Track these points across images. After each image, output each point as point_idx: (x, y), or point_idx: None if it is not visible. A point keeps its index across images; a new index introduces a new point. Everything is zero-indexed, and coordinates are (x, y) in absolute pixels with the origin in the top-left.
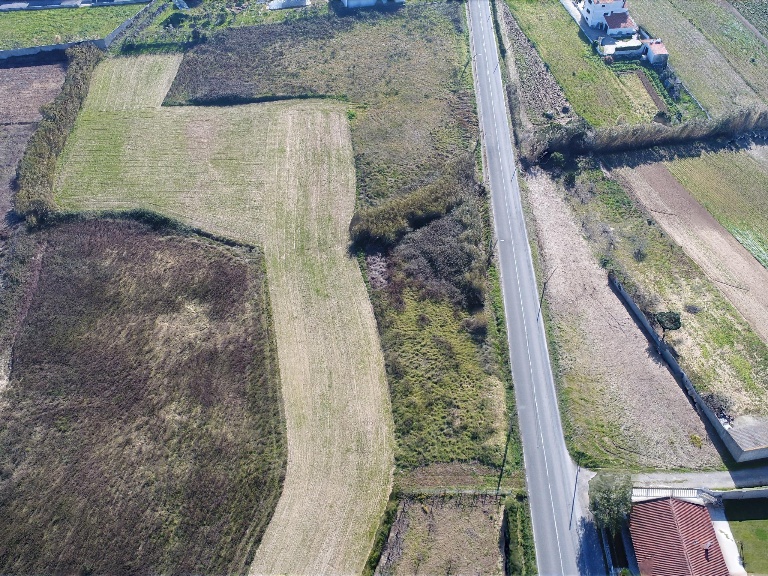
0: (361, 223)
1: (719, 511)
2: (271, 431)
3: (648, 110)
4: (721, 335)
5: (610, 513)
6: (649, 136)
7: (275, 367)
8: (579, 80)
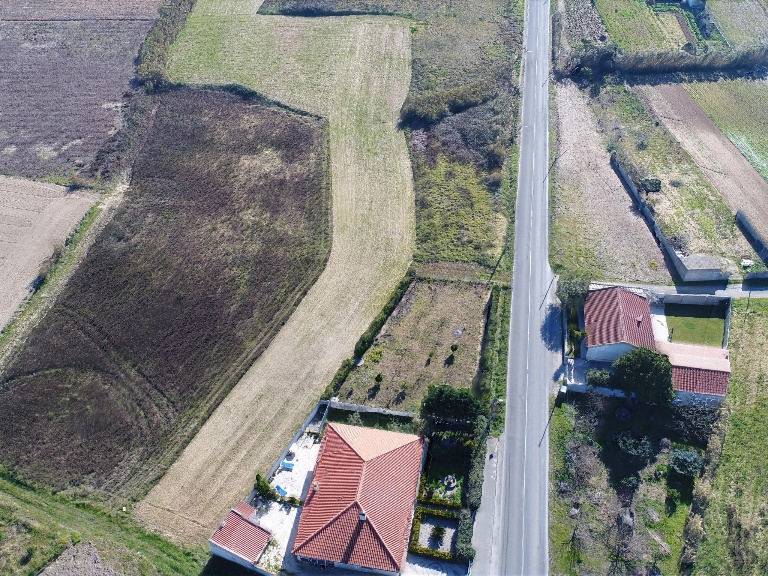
0: (410, 104)
1: (660, 309)
2: (321, 232)
3: (678, 43)
4: (695, 202)
5: (569, 292)
6: (673, 61)
7: (329, 194)
8: (620, 16)
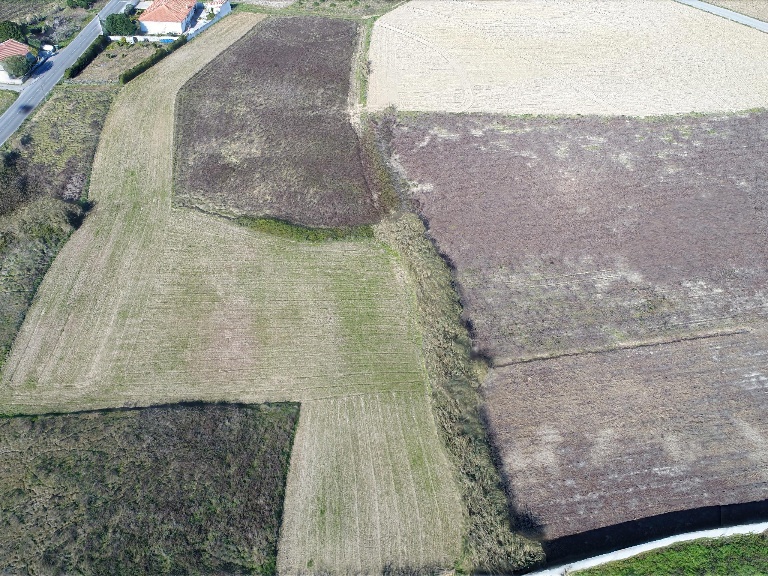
0: (69, 204)
1: None
2: None
3: None
4: None
5: None
6: None
7: None
8: None
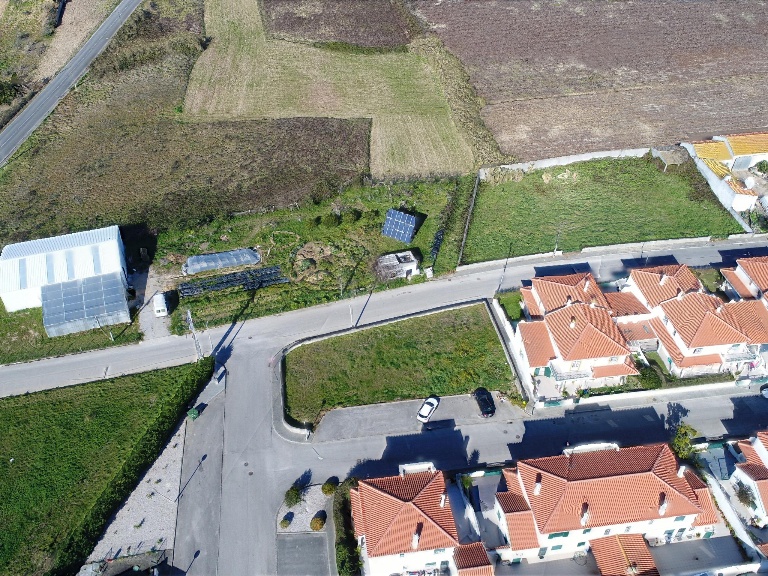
0: (198, 34)
1: None
2: None
3: None
4: (27, 4)
5: None
6: None
7: None
8: None
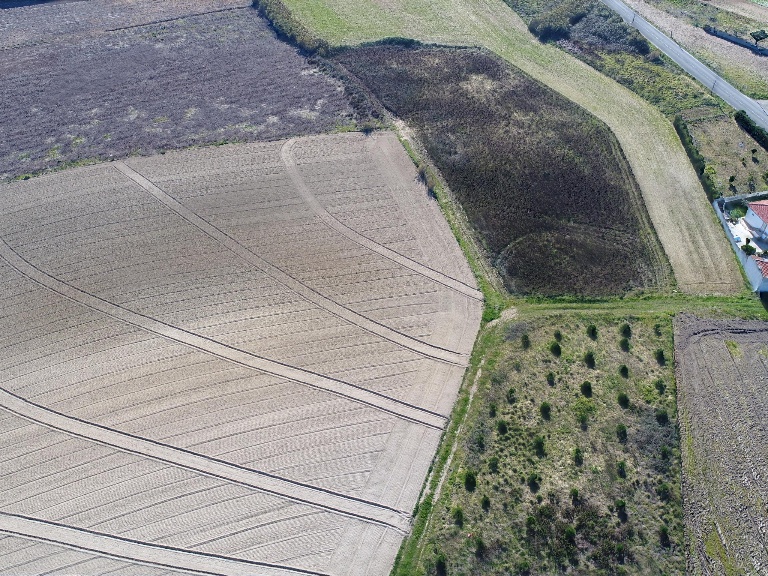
0: (543, 23)
1: None
2: (584, 114)
3: None
4: None
5: None
6: None
7: None
8: None
